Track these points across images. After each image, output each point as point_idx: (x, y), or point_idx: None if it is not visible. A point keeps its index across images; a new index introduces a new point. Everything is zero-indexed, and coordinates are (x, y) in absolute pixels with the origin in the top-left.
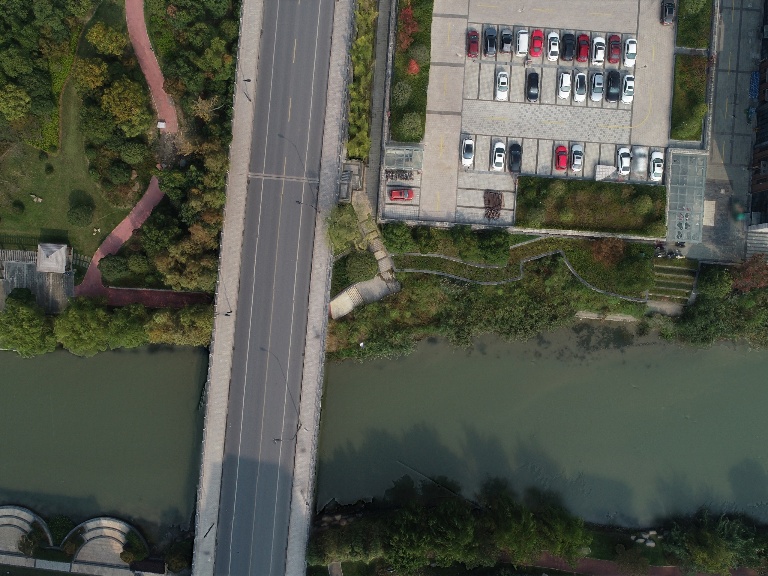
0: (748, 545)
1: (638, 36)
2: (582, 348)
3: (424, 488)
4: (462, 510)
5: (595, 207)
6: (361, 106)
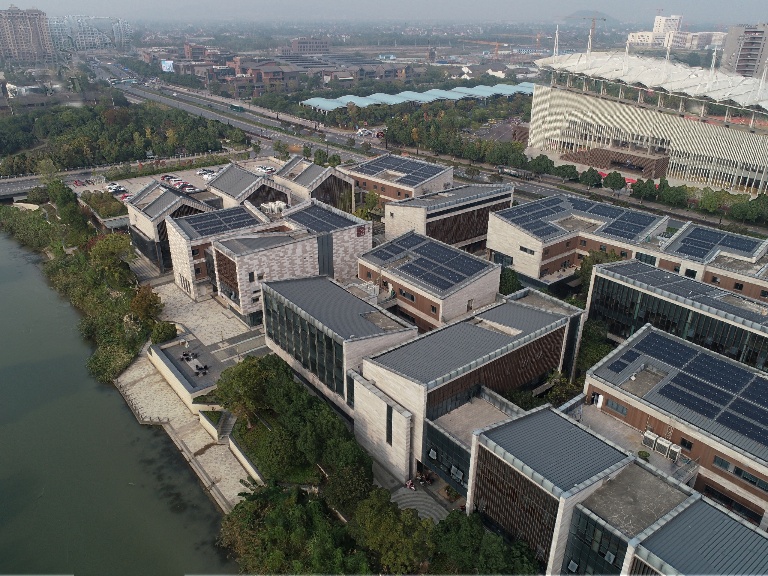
0: None
1: None
2: (22, 255)
3: None
4: None
5: None
6: None
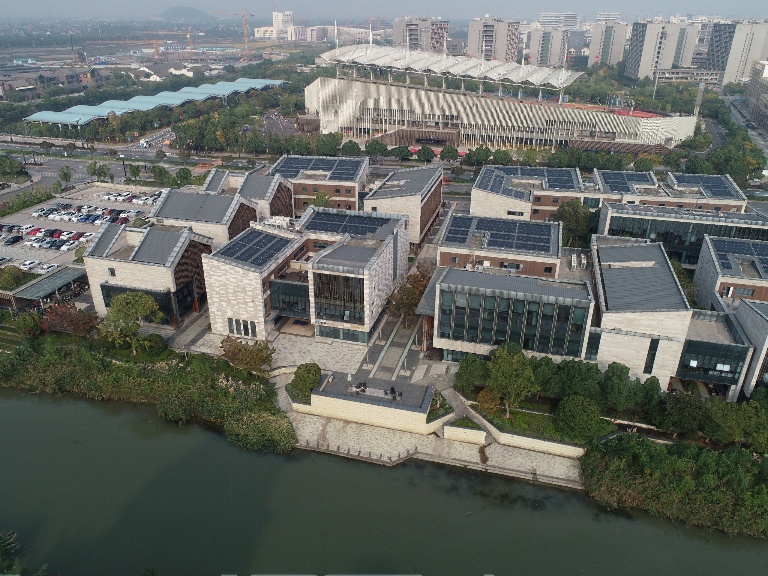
0: None
1: None
2: None
3: None
4: None
5: None
6: None
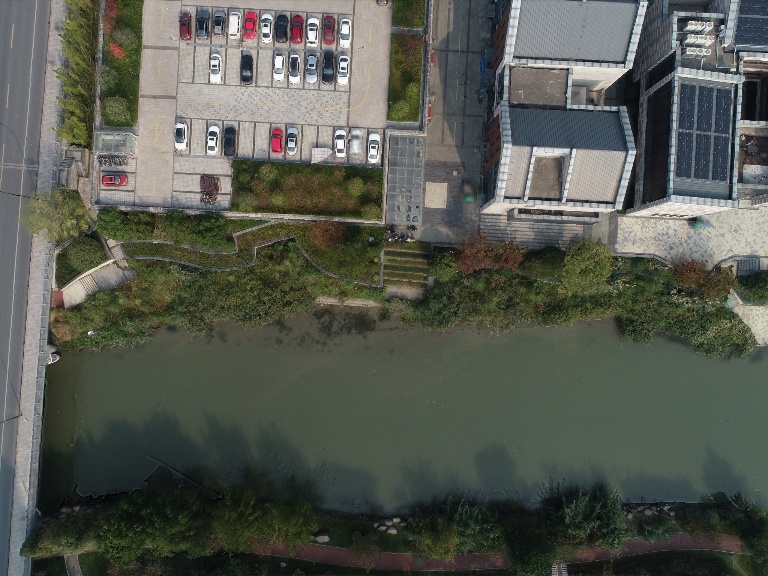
0: (483, 531)
1: (355, 17)
2: (324, 334)
3: (187, 479)
4: (185, 499)
5: (312, 190)
6: (73, 91)
